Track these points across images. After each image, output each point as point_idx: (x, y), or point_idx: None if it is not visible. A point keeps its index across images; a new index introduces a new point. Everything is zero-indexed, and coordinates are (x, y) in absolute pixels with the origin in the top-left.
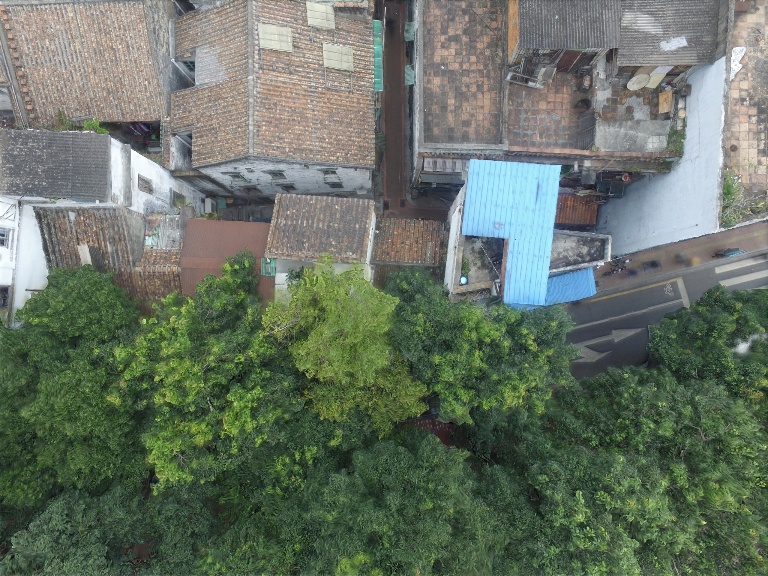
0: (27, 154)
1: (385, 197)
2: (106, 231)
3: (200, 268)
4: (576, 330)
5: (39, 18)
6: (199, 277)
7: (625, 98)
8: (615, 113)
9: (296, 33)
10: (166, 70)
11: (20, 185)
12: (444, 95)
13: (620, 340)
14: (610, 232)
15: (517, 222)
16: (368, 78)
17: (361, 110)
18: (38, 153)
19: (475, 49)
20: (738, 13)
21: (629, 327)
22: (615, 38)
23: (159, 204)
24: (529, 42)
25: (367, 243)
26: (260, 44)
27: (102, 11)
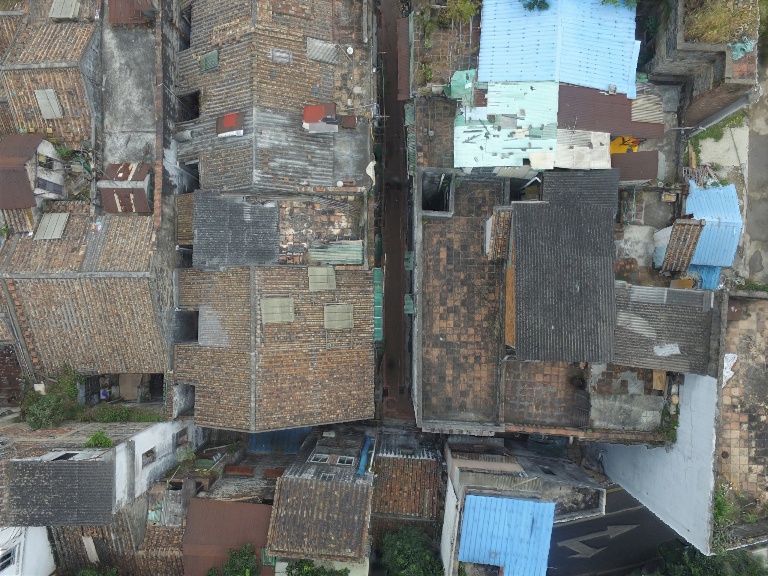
0: (34, 485)
1: (384, 384)
2: (110, 524)
3: (202, 556)
4: (572, 525)
5: (46, 288)
6: (201, 564)
7: (620, 373)
8: (610, 387)
9: (298, 299)
10: (170, 324)
11: (27, 516)
12: (442, 366)
13: (615, 536)
14: (605, 450)
15: (512, 552)
16: (368, 329)
17: (361, 362)
18: (45, 484)
19: (473, 321)
20: (730, 320)
21: (624, 523)
22: (609, 352)
23: (162, 462)
24: (525, 354)
25: (366, 539)
26: (262, 320)
27: (108, 284)
